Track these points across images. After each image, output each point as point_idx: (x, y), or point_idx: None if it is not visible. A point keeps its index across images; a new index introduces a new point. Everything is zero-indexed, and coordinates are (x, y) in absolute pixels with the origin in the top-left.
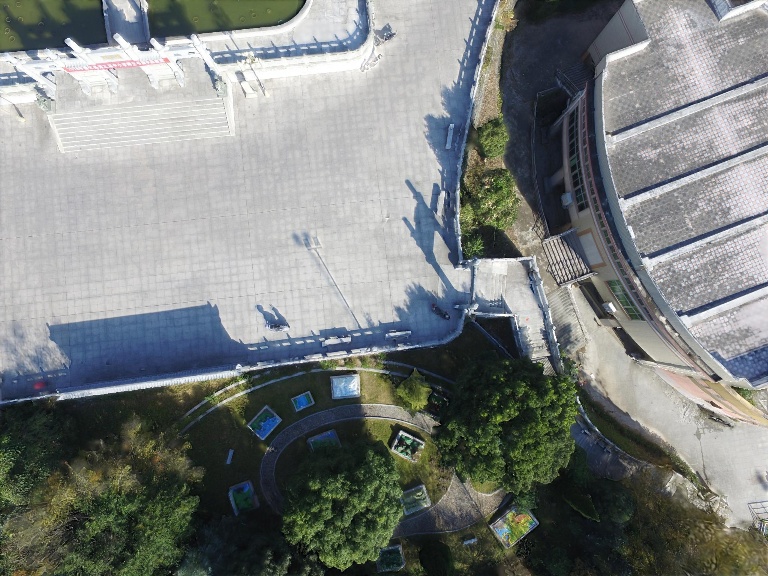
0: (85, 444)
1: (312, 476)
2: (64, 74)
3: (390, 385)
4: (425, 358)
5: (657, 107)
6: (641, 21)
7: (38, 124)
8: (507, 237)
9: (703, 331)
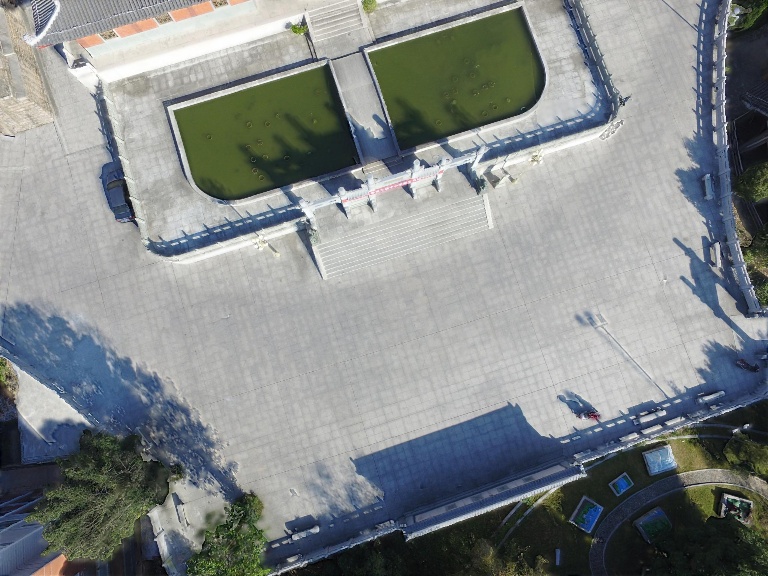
0: None
1: (706, 571)
2: None
3: (700, 448)
4: (727, 413)
5: None
6: None
7: (294, 256)
8: (758, 271)
9: None
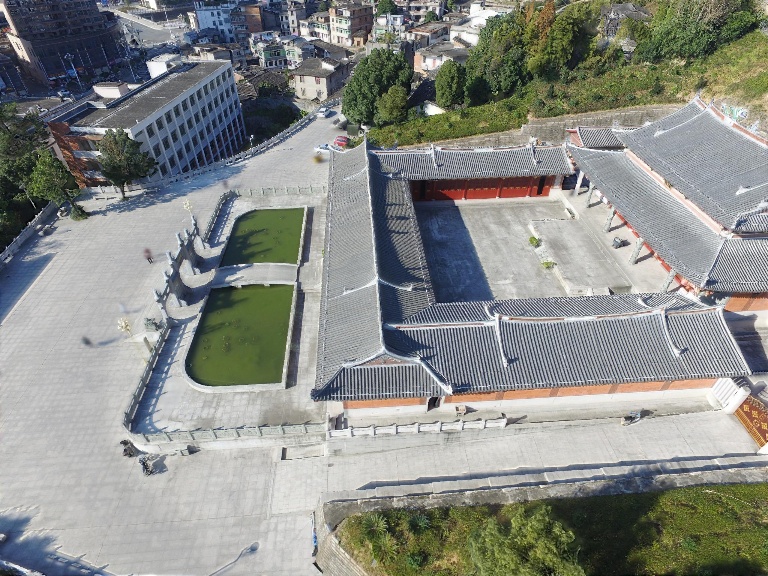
0: None
1: None
2: (210, 252)
3: None
4: None
5: None
6: None
7: None
8: None
9: None
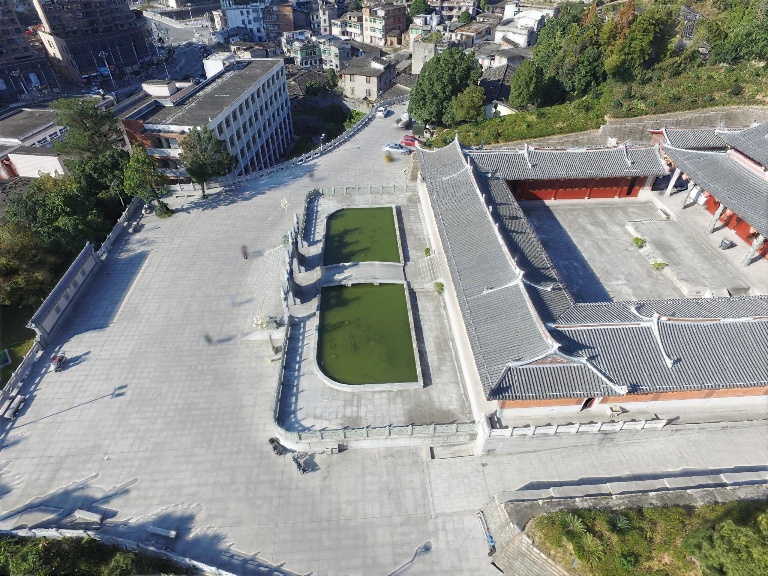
0: (65, 265)
1: None
2: (309, 251)
3: None
4: None
5: None
6: None
7: None
8: None
9: None
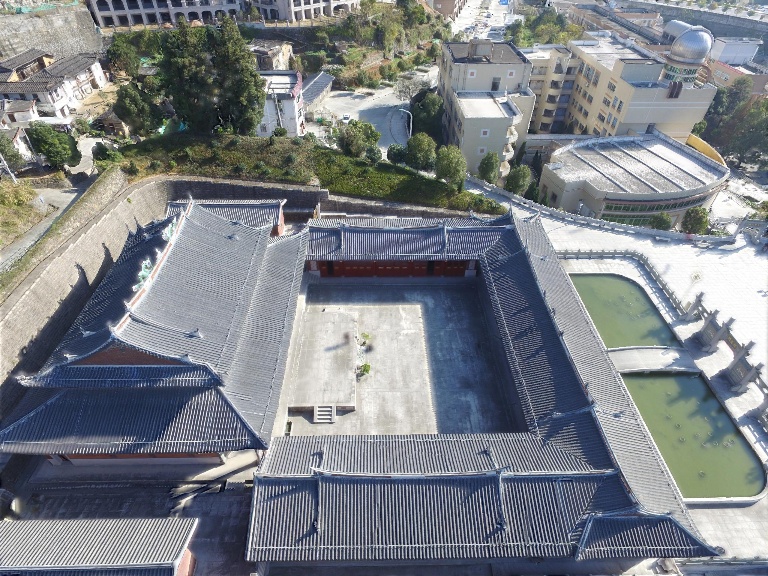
0: None
1: None
2: (739, 407)
3: None
4: None
5: (611, 184)
6: (578, 181)
7: None
8: None
9: (709, 181)
